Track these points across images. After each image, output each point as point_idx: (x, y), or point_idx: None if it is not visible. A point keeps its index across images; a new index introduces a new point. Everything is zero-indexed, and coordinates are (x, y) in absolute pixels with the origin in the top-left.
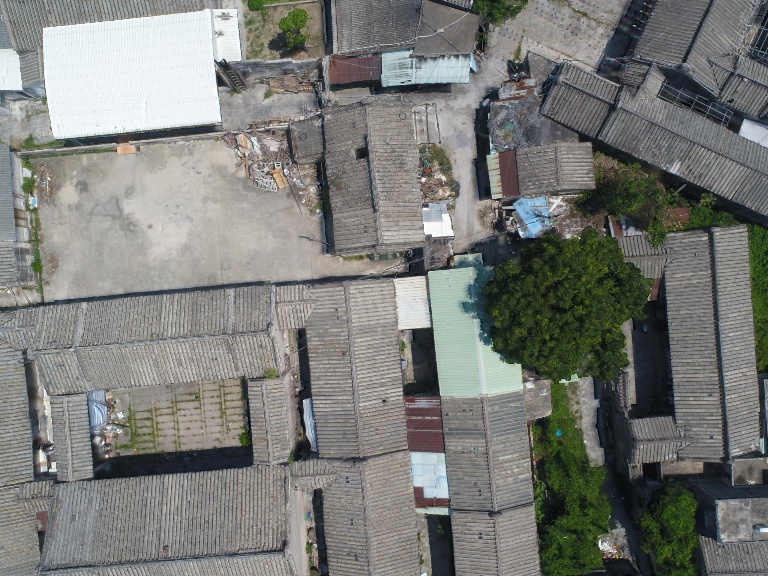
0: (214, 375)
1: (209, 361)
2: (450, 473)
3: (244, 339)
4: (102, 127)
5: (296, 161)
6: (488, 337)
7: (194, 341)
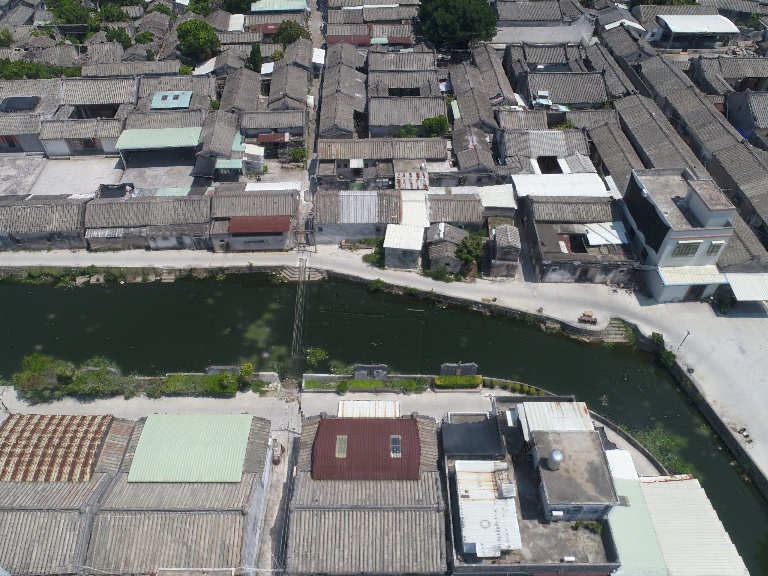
0: None
1: None
2: None
3: None
4: (691, 30)
5: (766, 53)
6: None
7: None
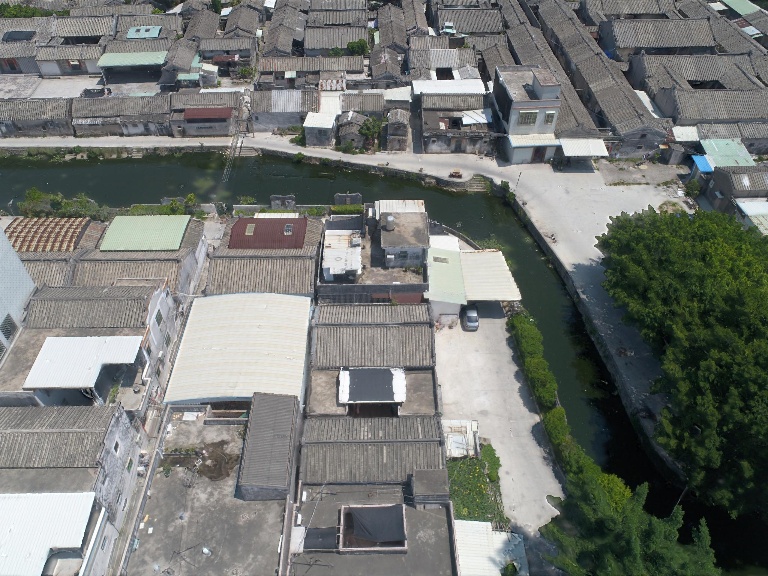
0: (651, 12)
1: (649, 7)
2: (757, 27)
3: (663, 1)
4: None
5: None
6: (753, 3)
7: (644, 1)
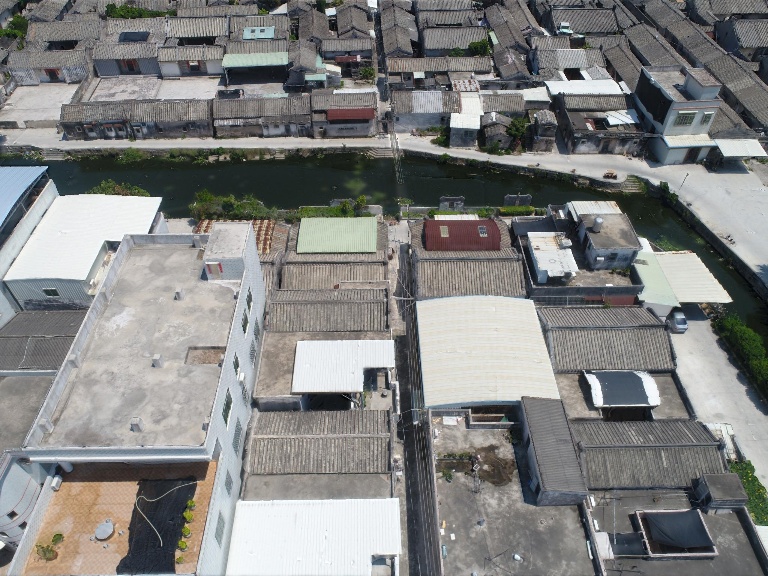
0: (760, 11)
1: (758, 7)
2: None
3: None
4: None
5: None
6: None
7: (752, 0)
